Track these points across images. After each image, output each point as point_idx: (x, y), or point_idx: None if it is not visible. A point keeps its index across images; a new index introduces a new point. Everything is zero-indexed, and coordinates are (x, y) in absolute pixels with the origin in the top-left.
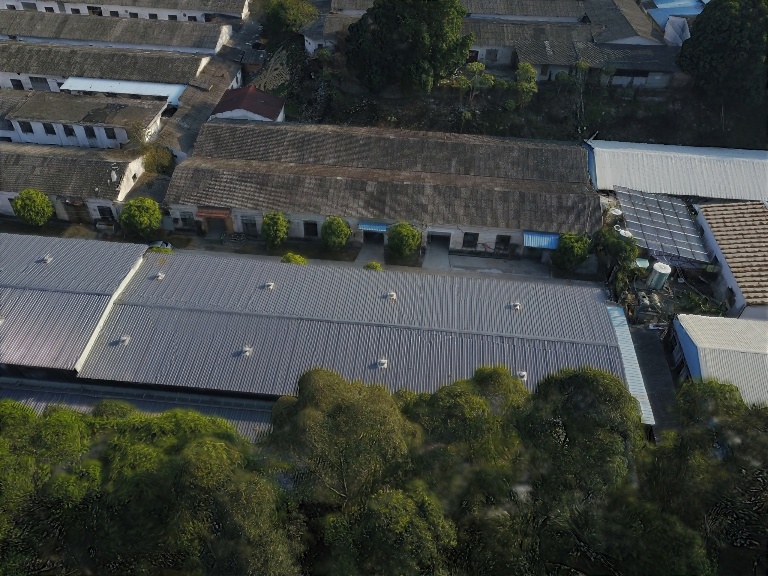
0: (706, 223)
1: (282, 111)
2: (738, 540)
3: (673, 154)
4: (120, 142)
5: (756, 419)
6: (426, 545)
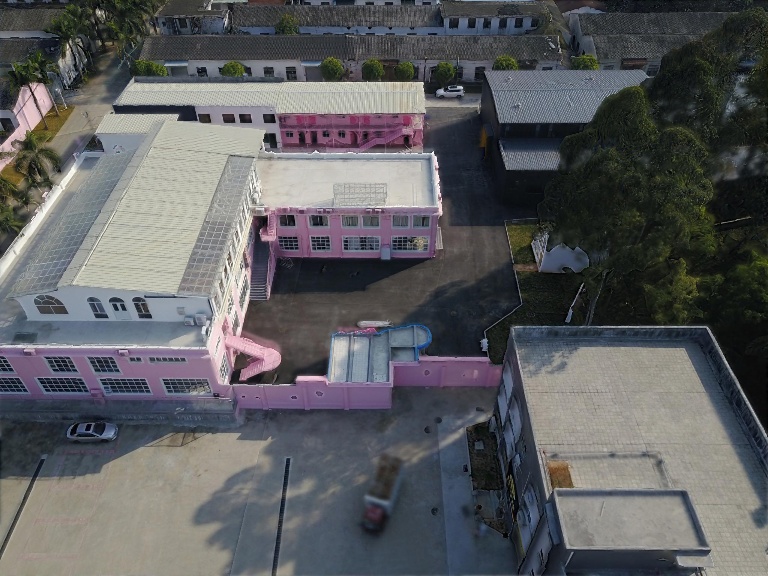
0: None
1: None
2: None
3: None
4: (526, 29)
5: None
6: None
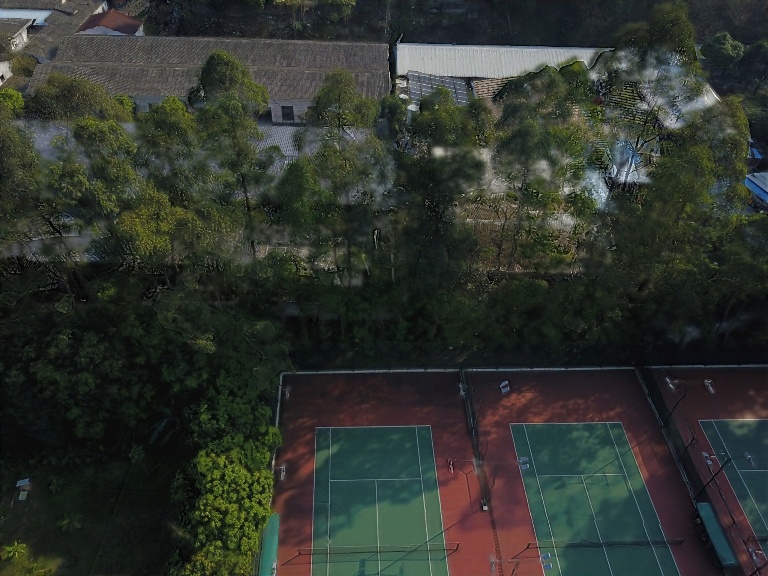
0: (475, 92)
1: (141, 31)
2: (366, 201)
3: (460, 47)
4: None
5: None
6: (105, 136)
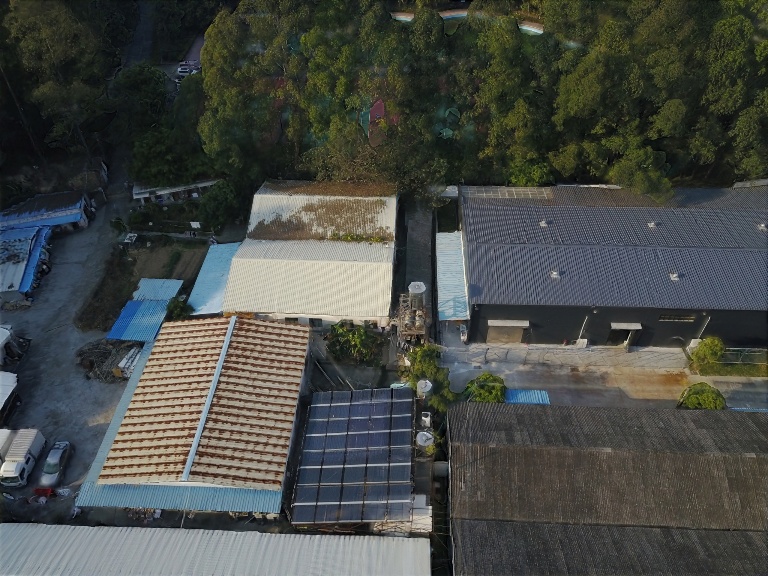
0: None
1: None
2: None
3: None
4: None
5: (497, 7)
6: None
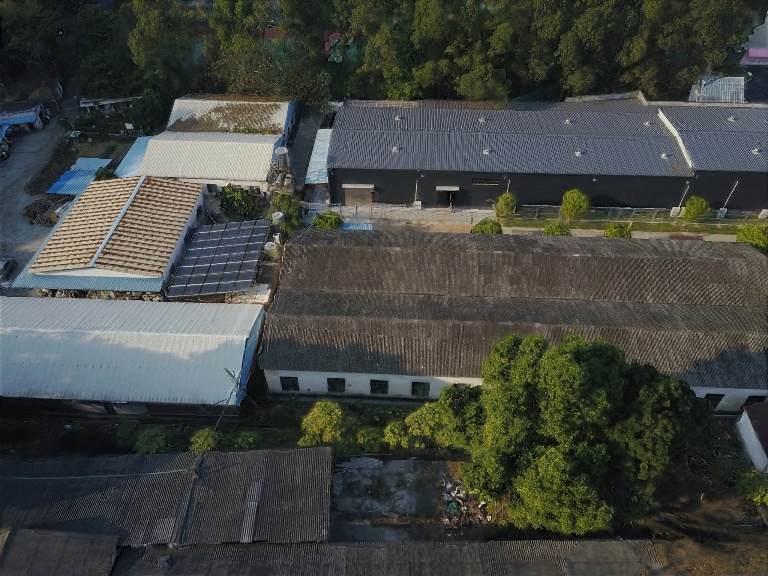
0: None
1: None
2: None
3: (138, 334)
4: None
5: None
6: None
